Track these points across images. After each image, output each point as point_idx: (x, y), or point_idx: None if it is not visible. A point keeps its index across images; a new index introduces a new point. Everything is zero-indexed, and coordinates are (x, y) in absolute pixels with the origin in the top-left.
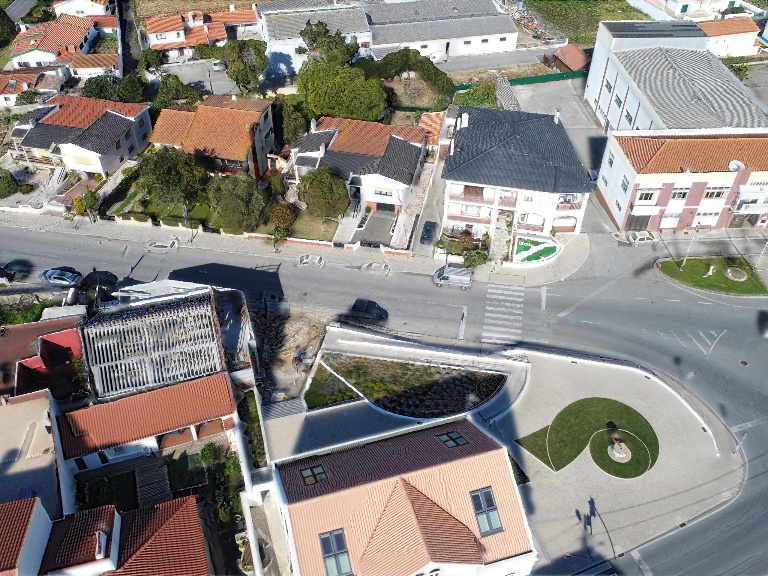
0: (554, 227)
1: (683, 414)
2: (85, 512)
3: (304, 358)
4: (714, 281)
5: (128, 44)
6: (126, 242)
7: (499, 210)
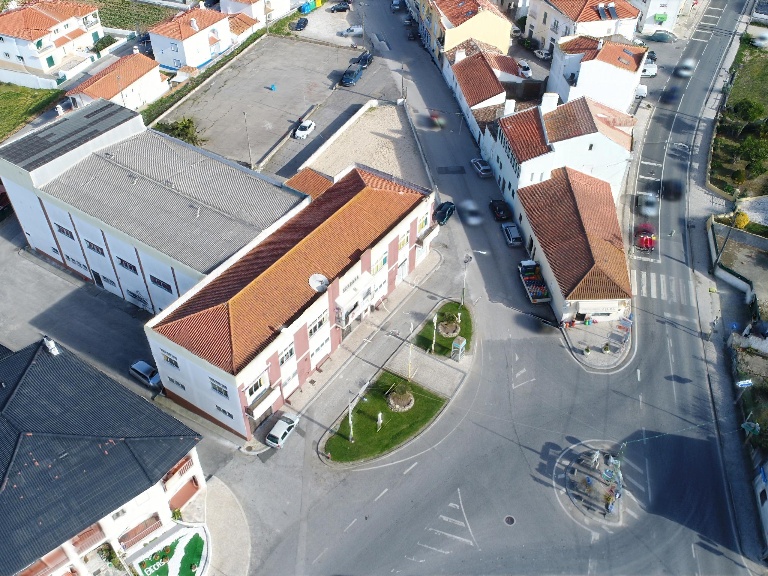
0: (170, 504)
1: None
2: None
3: None
4: (392, 429)
5: None
6: None
7: (82, 557)
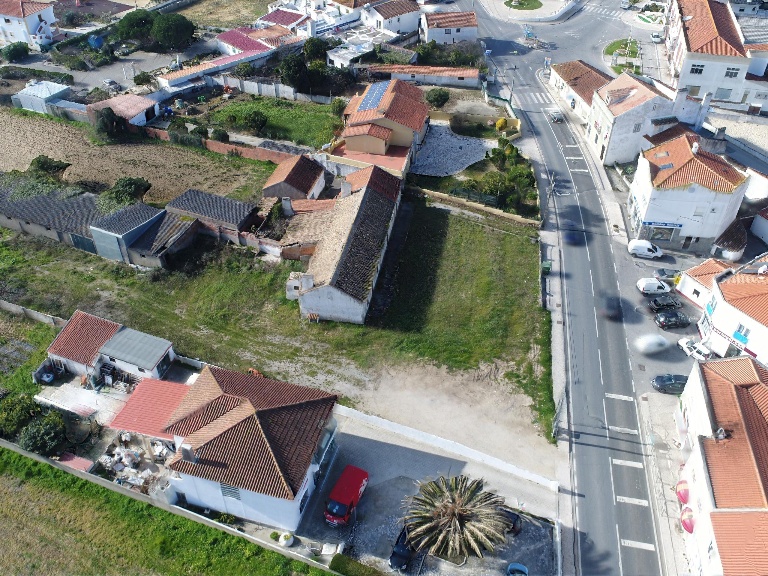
0: None
1: None
2: None
3: None
4: None
5: None
6: None
7: None
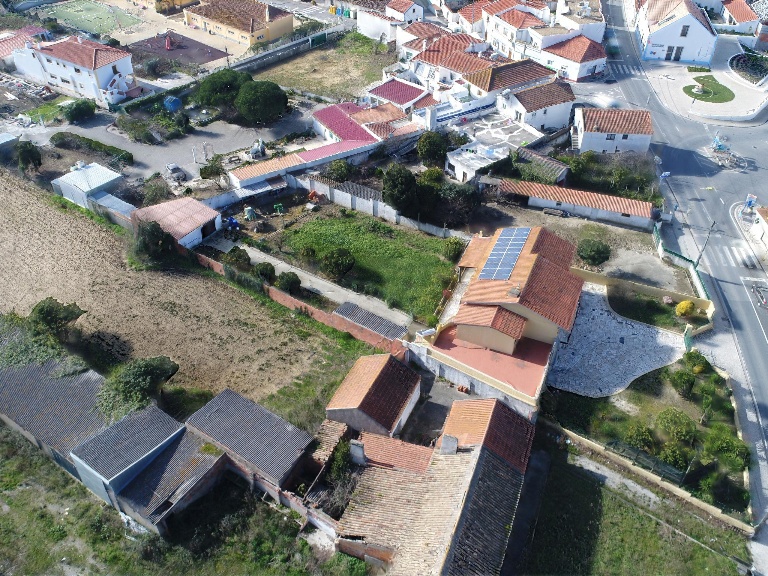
0: None
1: (718, 113)
2: None
3: None
4: None
5: None
6: None
7: None
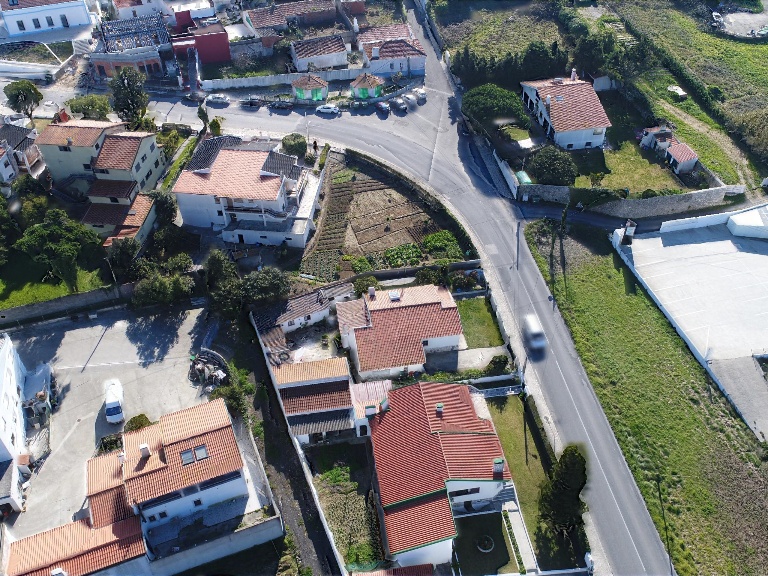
0: None
1: None
2: None
3: None
4: None
5: (318, 545)
6: (182, 122)
7: None
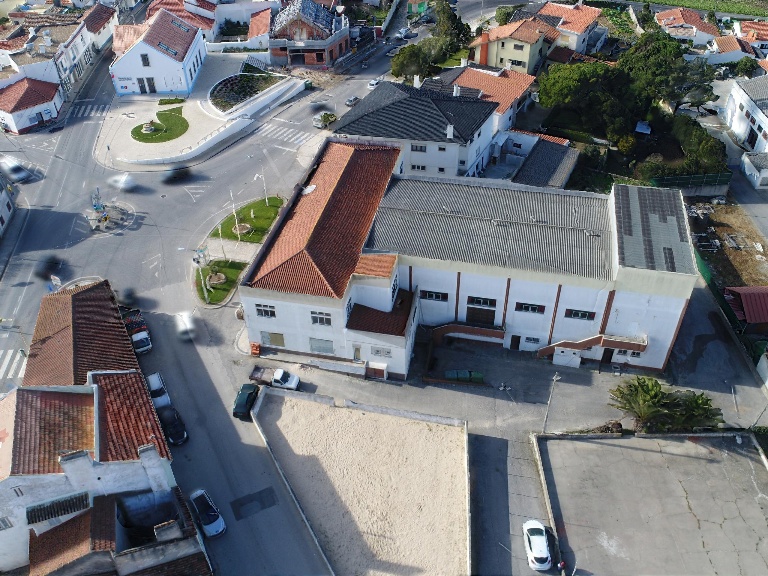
0: None
1: (151, 156)
2: (215, 8)
3: (293, 77)
4: (244, 215)
5: None
6: None
7: None
